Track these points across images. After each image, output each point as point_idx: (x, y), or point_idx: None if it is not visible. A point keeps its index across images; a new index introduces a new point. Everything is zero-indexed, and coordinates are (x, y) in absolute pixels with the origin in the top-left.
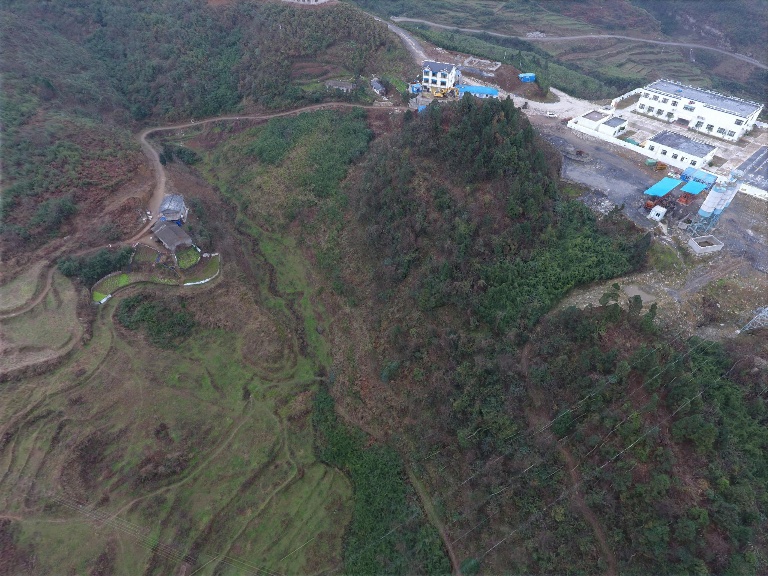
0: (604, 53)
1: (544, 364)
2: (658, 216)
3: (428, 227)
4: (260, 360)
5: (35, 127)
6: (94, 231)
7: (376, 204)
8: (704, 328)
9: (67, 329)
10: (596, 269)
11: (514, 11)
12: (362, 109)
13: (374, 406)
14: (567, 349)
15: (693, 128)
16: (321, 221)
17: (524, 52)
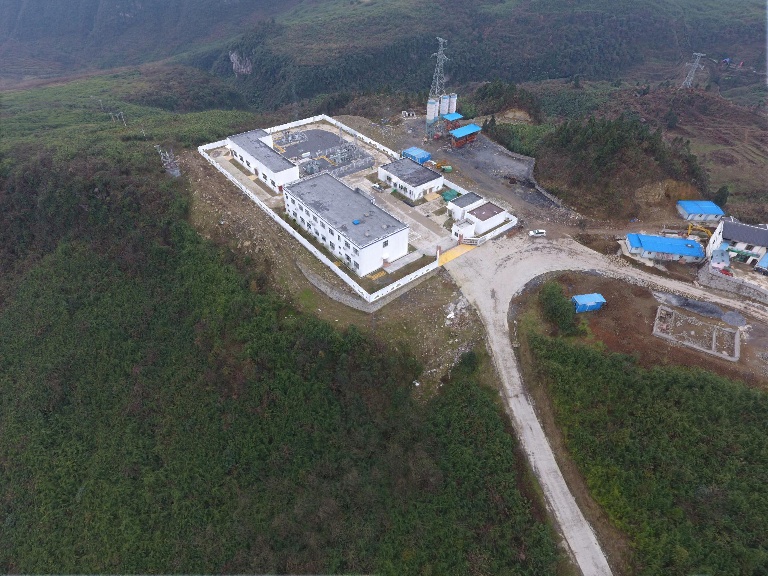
0: None
1: None
2: None
3: None
4: None
5: None
6: None
7: None
8: None
9: None
10: None
11: None
12: None
13: None
14: None
15: None
16: None
17: None
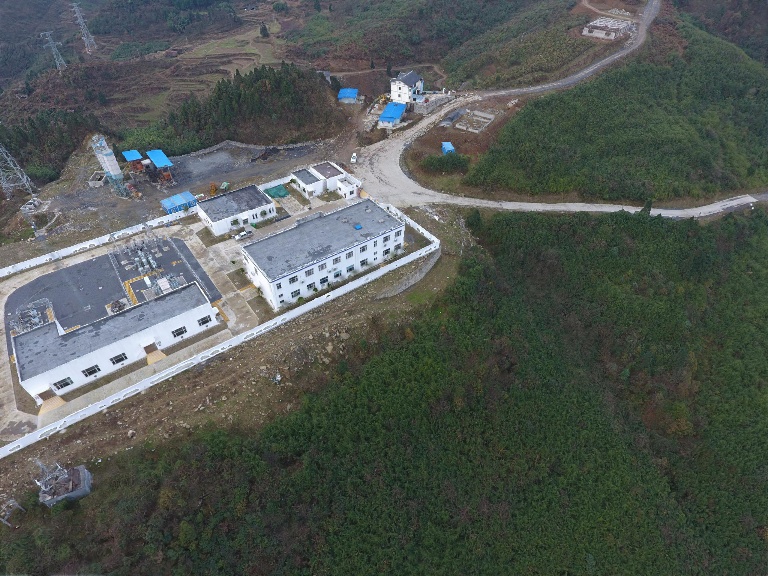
0: None
1: None
2: None
3: None
4: None
5: None
6: None
7: None
8: (57, 182)
9: None
10: None
11: None
12: None
13: None
14: None
15: None
16: None
17: None
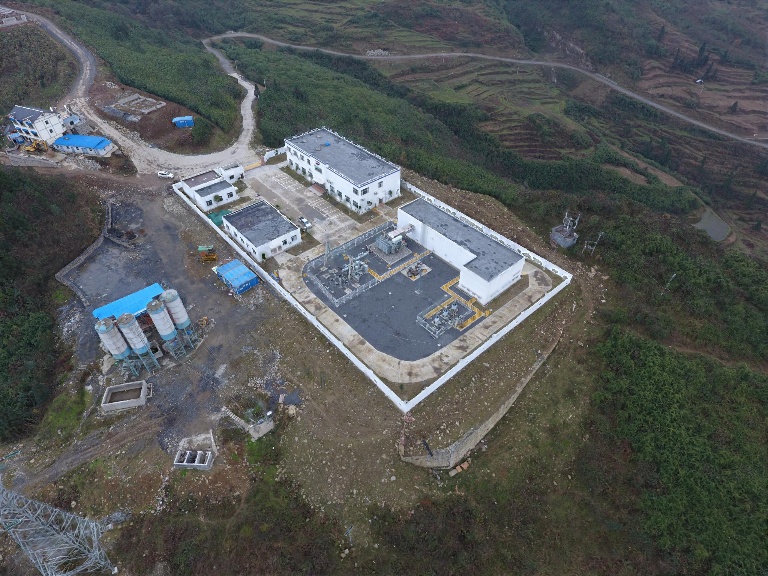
0: (447, 73)
1: None
2: None
3: None
4: None
5: None
6: None
7: None
8: None
9: None
10: None
11: (359, 26)
12: None
13: None
14: None
15: (328, 193)
16: None
17: (336, 74)
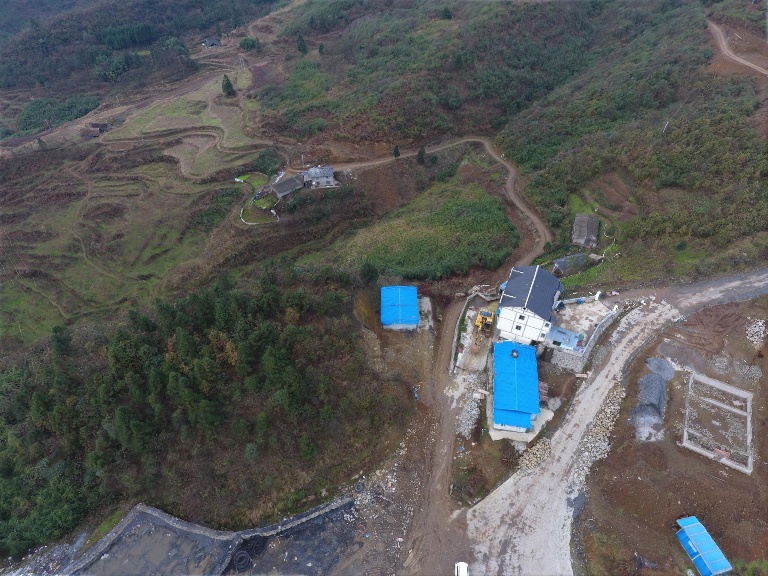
0: None
1: None
2: None
3: None
4: None
5: (395, 79)
6: None
7: None
8: None
9: (205, 171)
10: None
11: None
12: (497, 256)
13: None
14: None
15: None
16: None
17: None
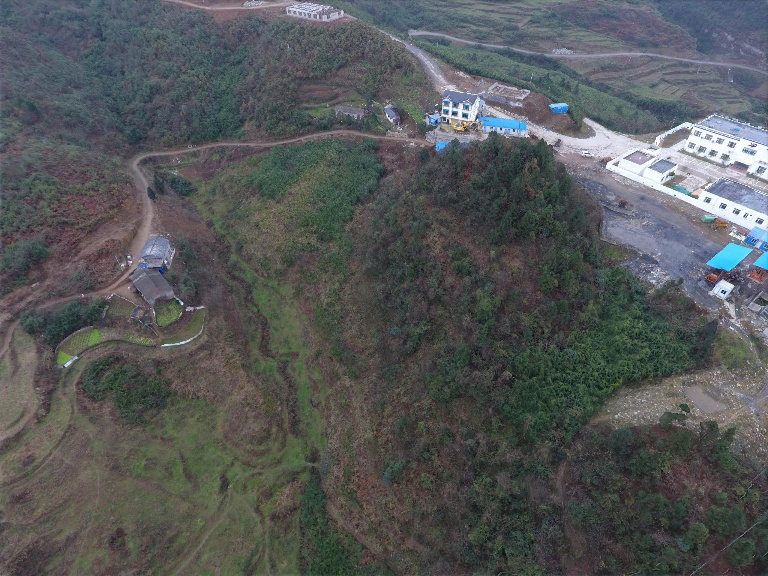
0: (636, 72)
1: (587, 499)
2: (724, 294)
3: (443, 296)
4: (243, 441)
5: (11, 156)
6: (65, 279)
7: (384, 259)
8: None
9: (20, 402)
10: (650, 364)
11: (540, 26)
12: (373, 140)
13: (372, 513)
14: (619, 486)
15: (753, 174)
16: (322, 270)
17: (551, 71)
